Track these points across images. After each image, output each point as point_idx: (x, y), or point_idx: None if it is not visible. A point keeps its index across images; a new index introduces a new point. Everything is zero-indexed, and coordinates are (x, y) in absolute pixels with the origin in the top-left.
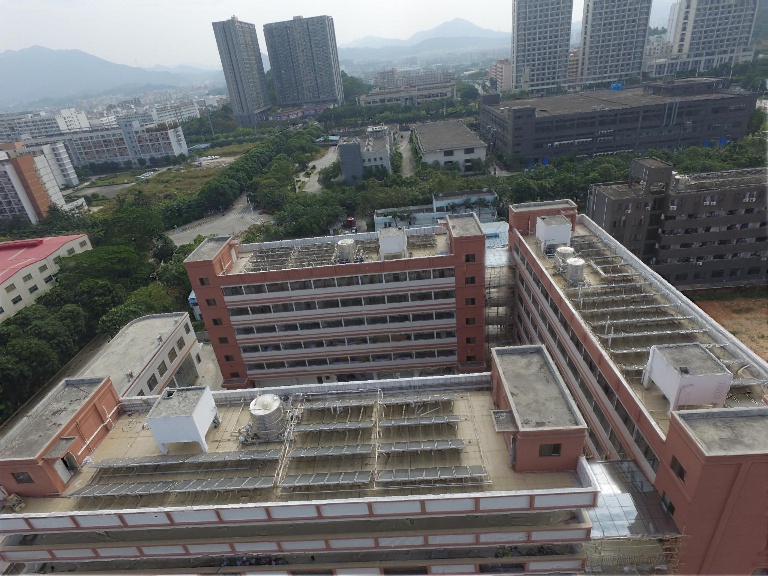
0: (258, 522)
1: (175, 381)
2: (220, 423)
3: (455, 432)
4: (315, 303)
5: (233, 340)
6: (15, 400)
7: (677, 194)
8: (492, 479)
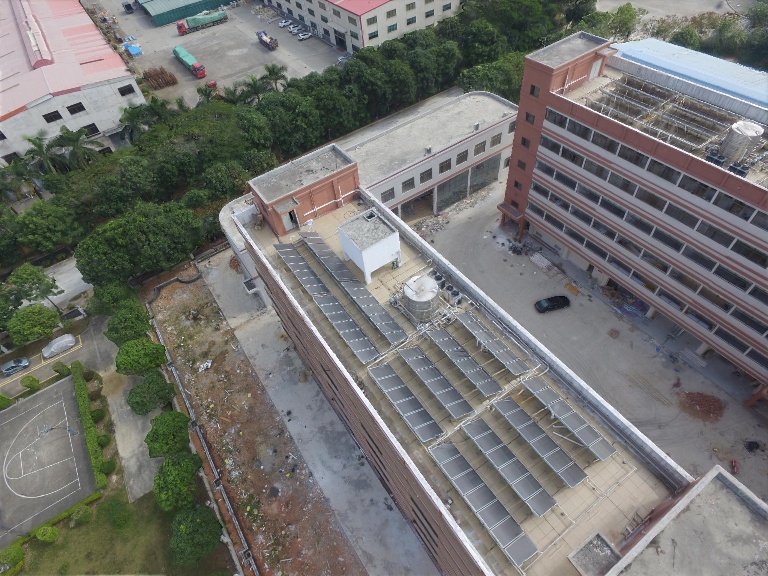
0: (342, 377)
1: (469, 174)
2: (398, 267)
3: (562, 488)
4: (636, 188)
5: (530, 170)
6: (374, 114)
7: None
8: (531, 572)
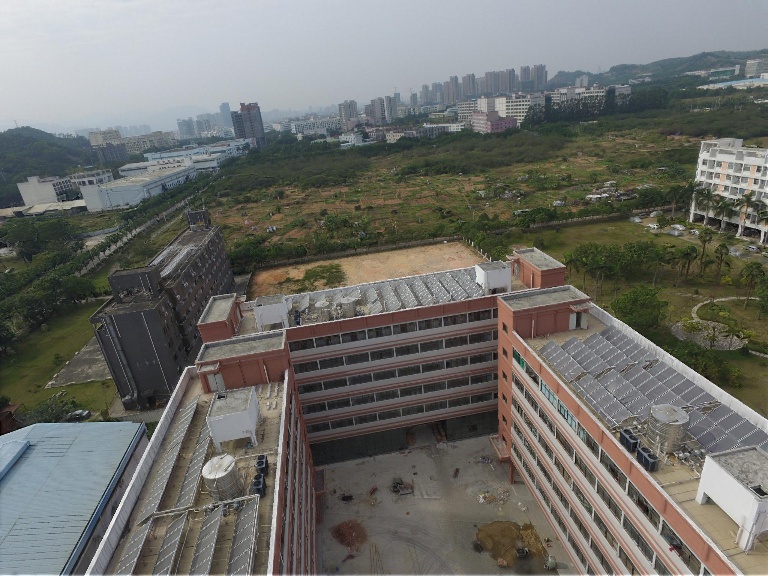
0: None
1: None
2: None
3: None
4: None
5: None
6: None
7: (173, 285)
8: None
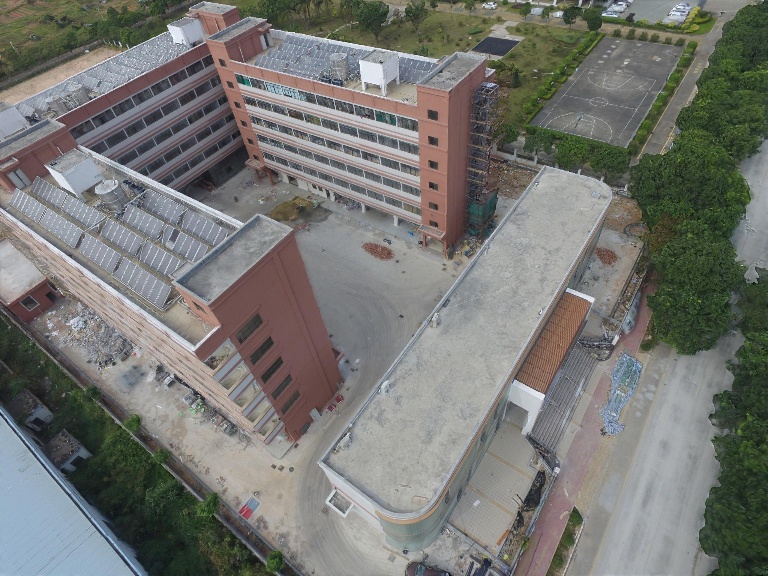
0: None
1: None
2: None
3: None
4: None
5: None
6: None
7: None
8: None
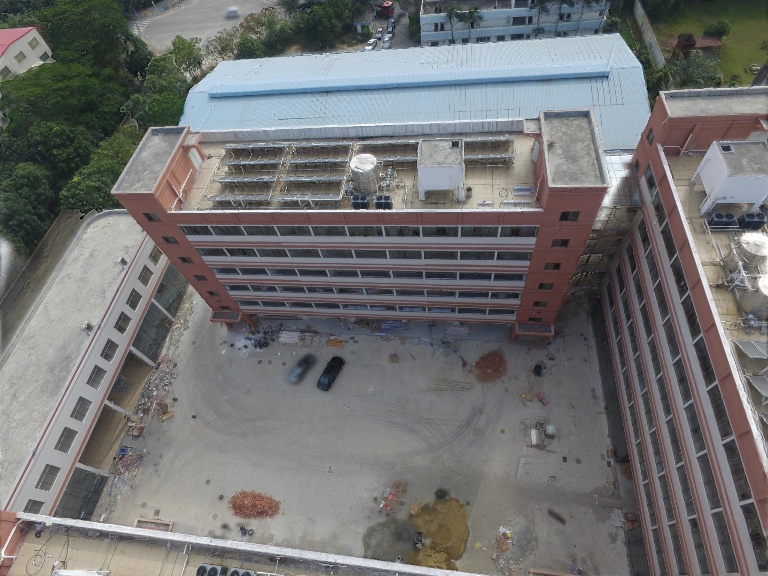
0: None
1: (156, 304)
2: None
3: None
4: (318, 251)
5: (213, 278)
6: None
7: None
8: None
